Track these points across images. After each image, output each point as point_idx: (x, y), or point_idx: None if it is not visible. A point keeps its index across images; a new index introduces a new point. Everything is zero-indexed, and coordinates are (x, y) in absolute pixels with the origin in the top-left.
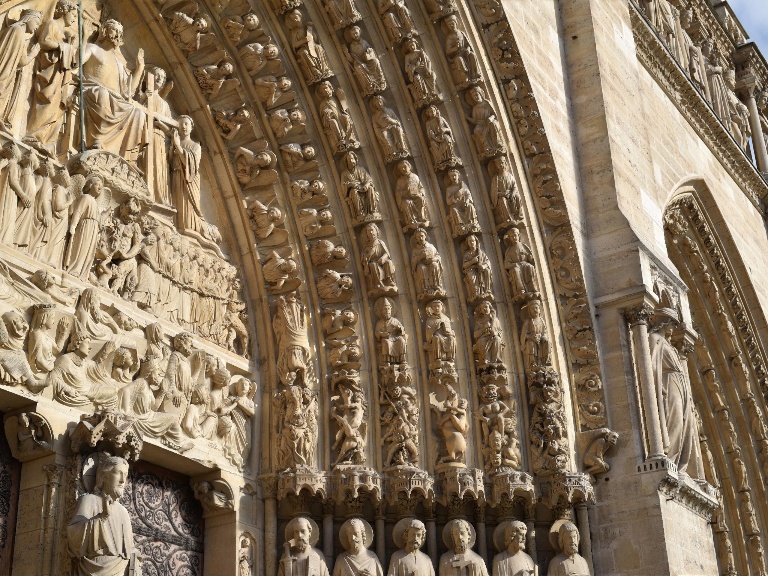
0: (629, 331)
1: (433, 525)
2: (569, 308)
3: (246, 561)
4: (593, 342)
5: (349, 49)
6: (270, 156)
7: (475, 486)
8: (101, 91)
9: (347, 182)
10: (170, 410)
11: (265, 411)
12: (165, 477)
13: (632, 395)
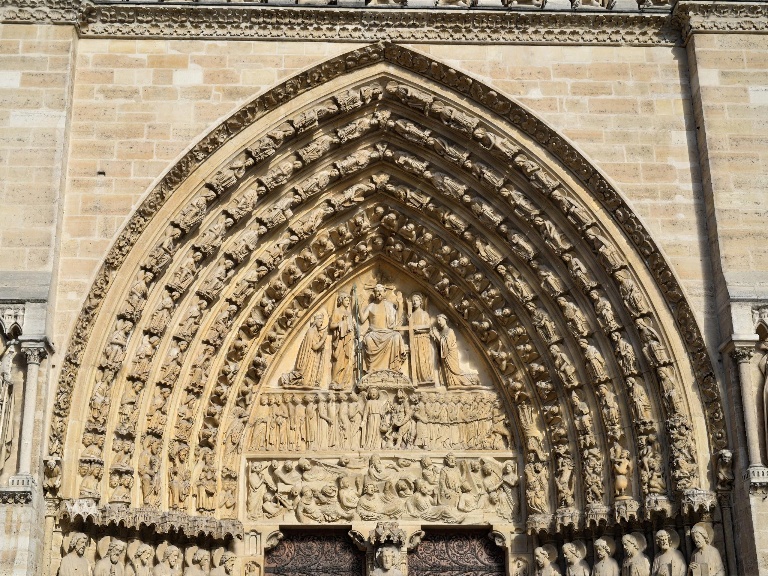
0: None
1: None
2: (698, 361)
3: (519, 575)
4: (715, 383)
5: (507, 239)
6: (488, 322)
7: (626, 512)
8: (366, 338)
9: (533, 323)
10: (446, 502)
11: None
12: (471, 533)
13: (739, 421)
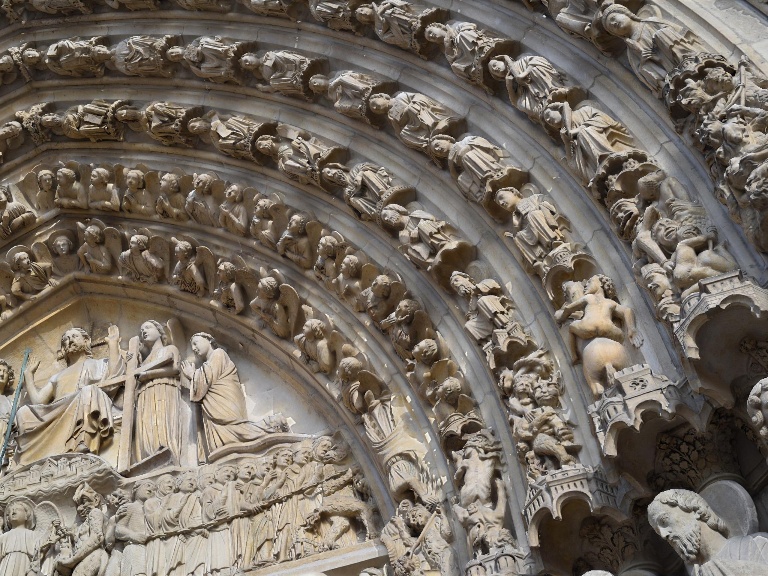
0: None
1: None
2: None
3: None
4: None
5: None
6: (272, 277)
7: (625, 407)
8: None
9: None
10: None
11: None
12: None
13: None
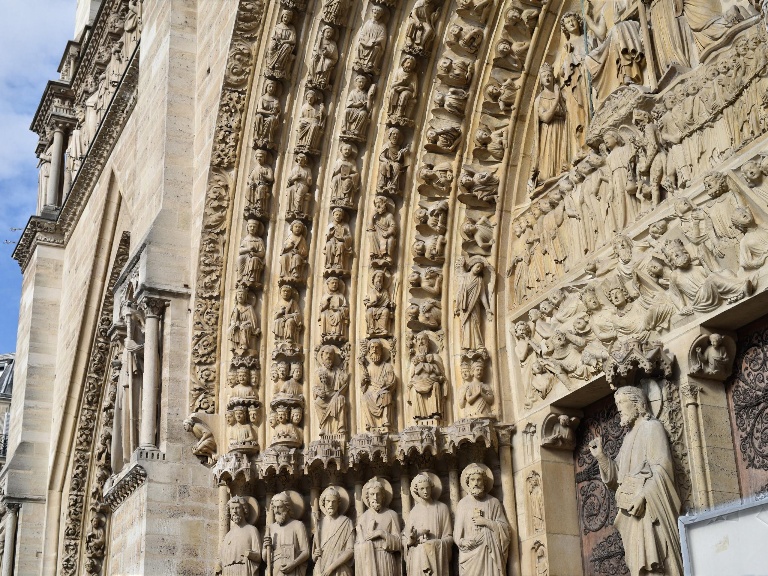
0: None
1: None
2: None
3: None
4: None
5: None
6: None
7: None
8: None
9: None
10: None
11: None
12: None
13: None
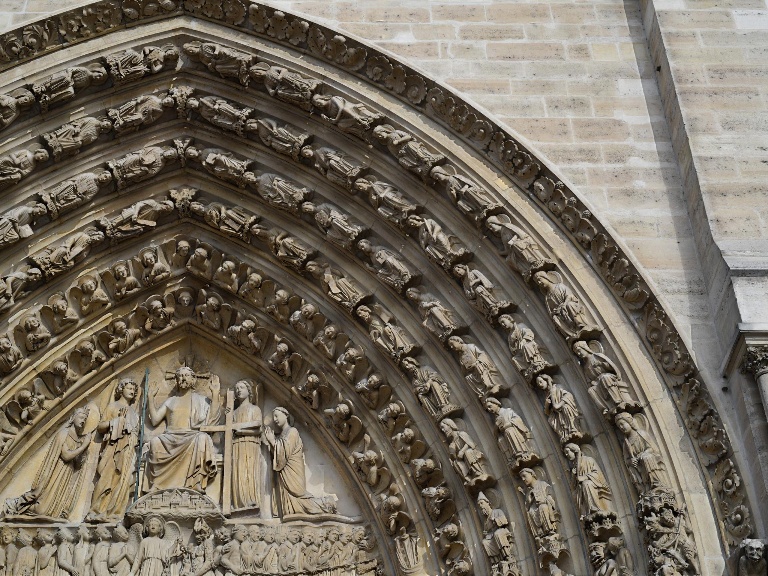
0: None
1: None
2: (686, 398)
3: None
4: (720, 428)
5: (371, 263)
6: (347, 405)
7: None
8: (151, 441)
9: (414, 390)
10: None
11: None
12: None
13: None
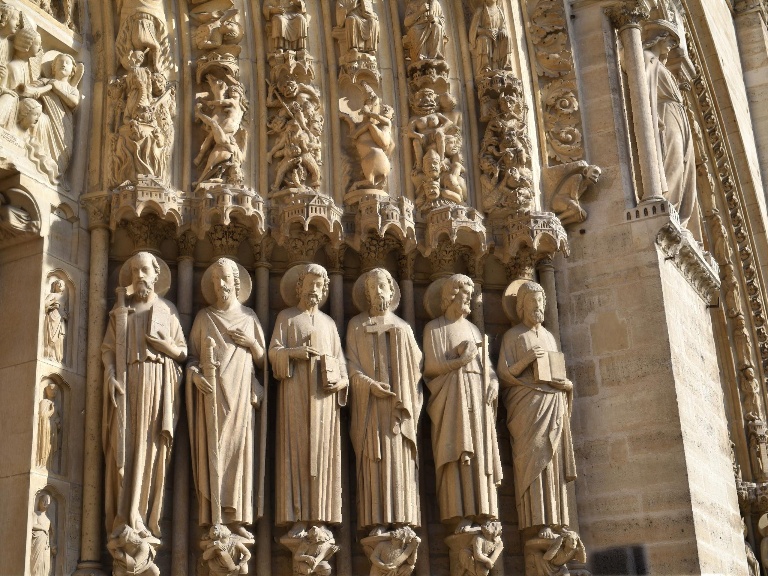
0: (615, 40)
1: (339, 279)
2: (535, 3)
3: (57, 311)
4: (567, 49)
5: None
6: None
7: (402, 220)
8: None
9: None
10: None
11: (96, 106)
12: None
13: (620, 120)
